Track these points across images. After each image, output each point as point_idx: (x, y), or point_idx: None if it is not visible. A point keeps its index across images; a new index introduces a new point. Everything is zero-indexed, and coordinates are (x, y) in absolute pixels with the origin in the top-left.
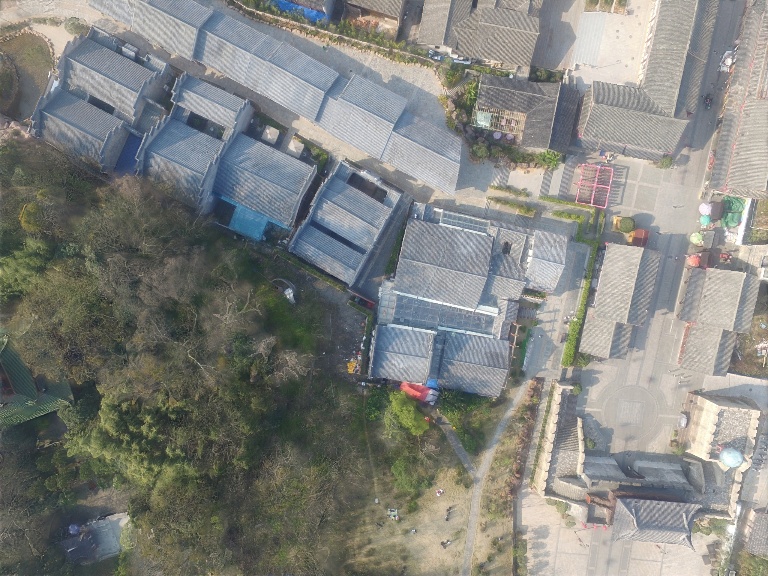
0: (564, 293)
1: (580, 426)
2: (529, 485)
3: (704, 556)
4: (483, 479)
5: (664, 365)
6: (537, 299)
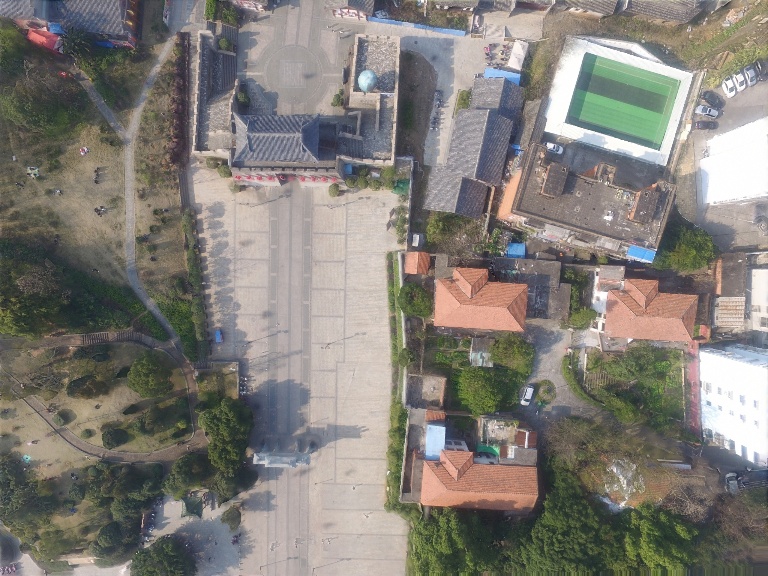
0: None
1: (235, 84)
2: (197, 158)
3: (387, 223)
4: (133, 140)
5: (322, 21)
6: None
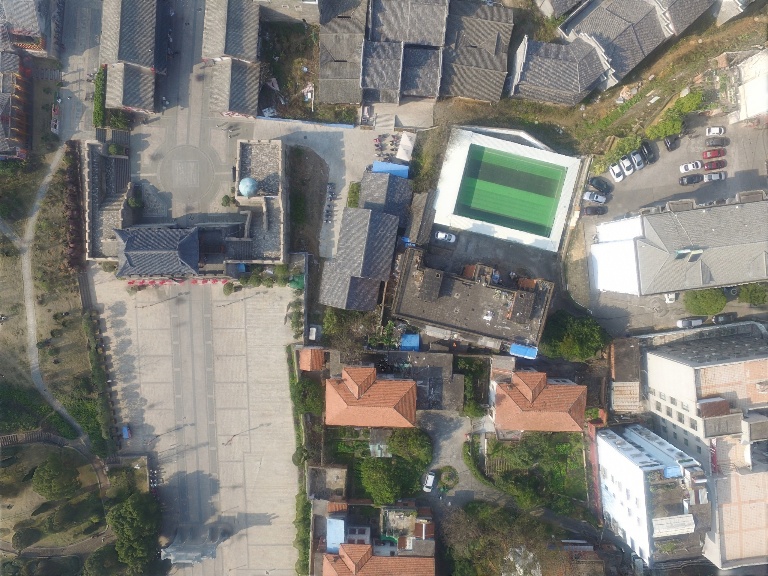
0: (85, 51)
1: (128, 188)
2: None
3: (285, 317)
4: (29, 248)
5: (211, 120)
6: (41, 52)
